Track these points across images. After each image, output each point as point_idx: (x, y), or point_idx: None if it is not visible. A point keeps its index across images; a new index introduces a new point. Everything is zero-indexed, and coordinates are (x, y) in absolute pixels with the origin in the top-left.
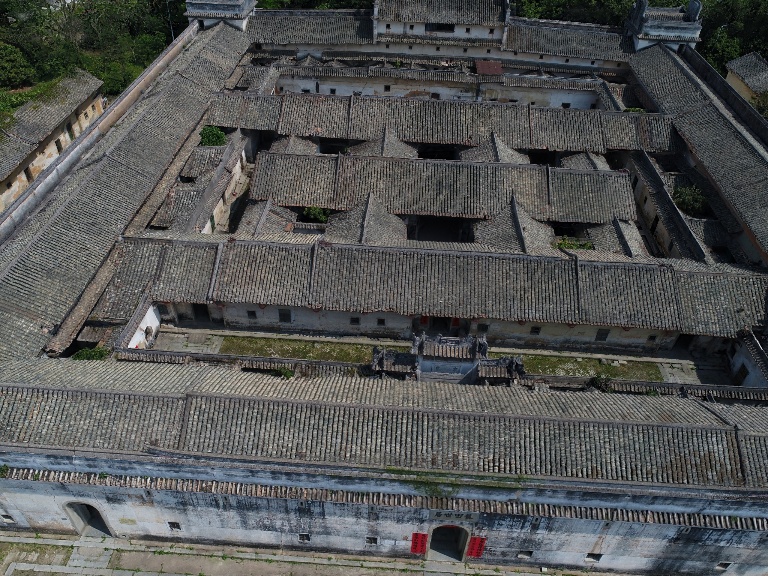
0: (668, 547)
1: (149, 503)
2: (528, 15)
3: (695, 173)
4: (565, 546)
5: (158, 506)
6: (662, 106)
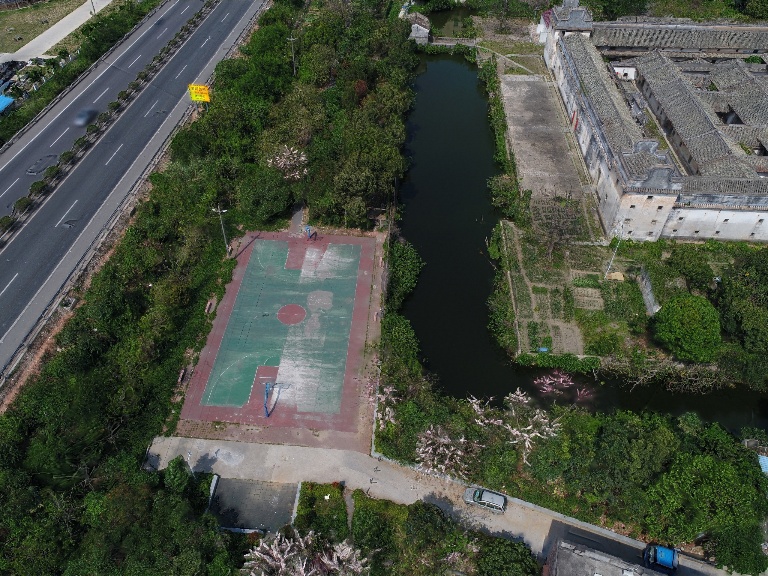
0: None
1: None
2: None
3: None
4: None
5: None
6: None
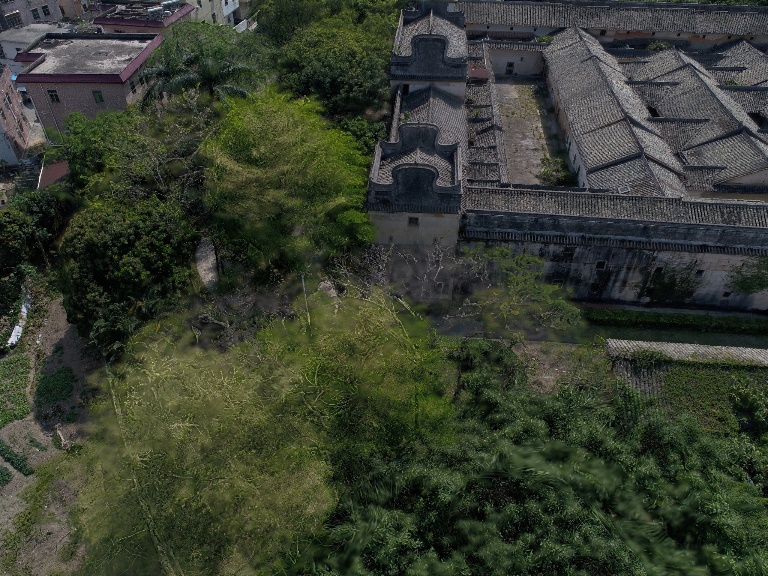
0: None
1: None
2: None
3: (624, 41)
4: None
5: None
6: (554, 25)
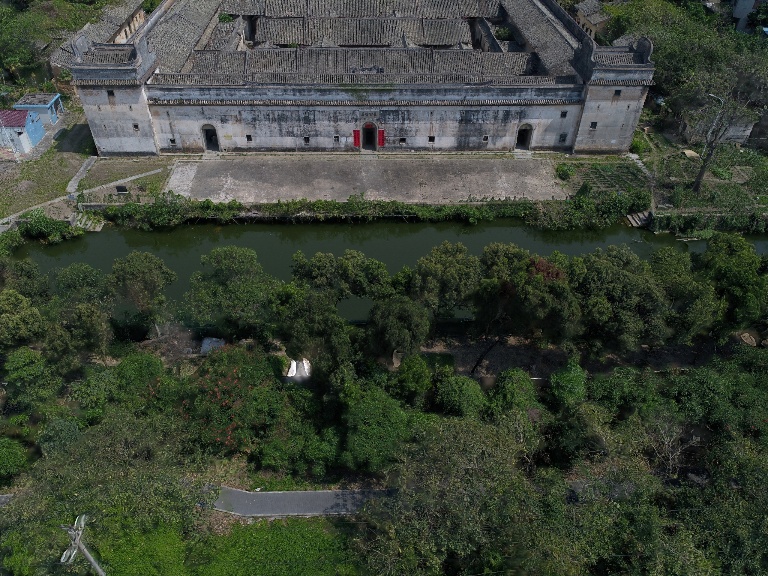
0: (460, 127)
1: (239, 121)
2: None
3: (510, 25)
4: (418, 132)
5: (243, 123)
6: None
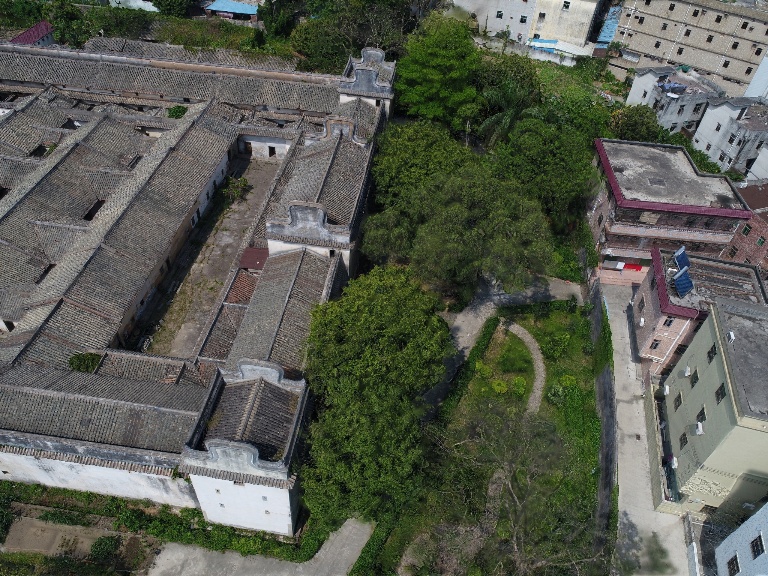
0: None
1: None
2: (354, 284)
3: None
4: None
5: None
6: None
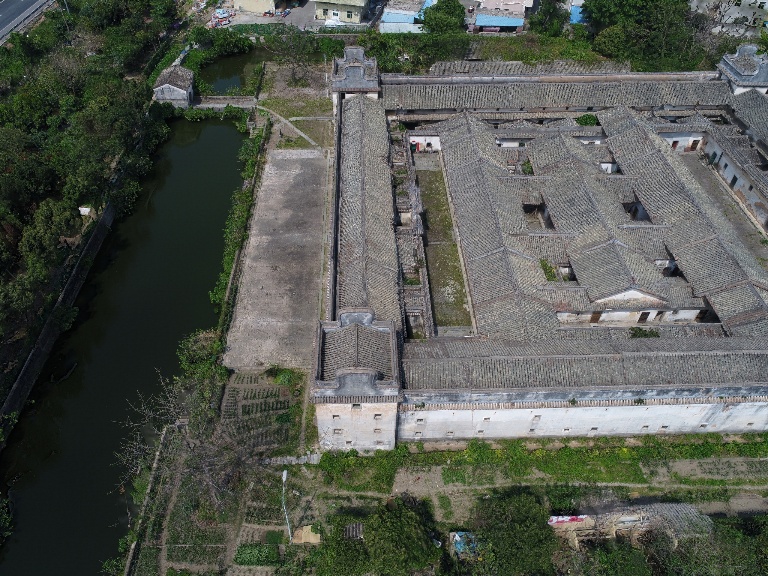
0: None
1: None
2: None
3: None
4: None
5: None
6: None
